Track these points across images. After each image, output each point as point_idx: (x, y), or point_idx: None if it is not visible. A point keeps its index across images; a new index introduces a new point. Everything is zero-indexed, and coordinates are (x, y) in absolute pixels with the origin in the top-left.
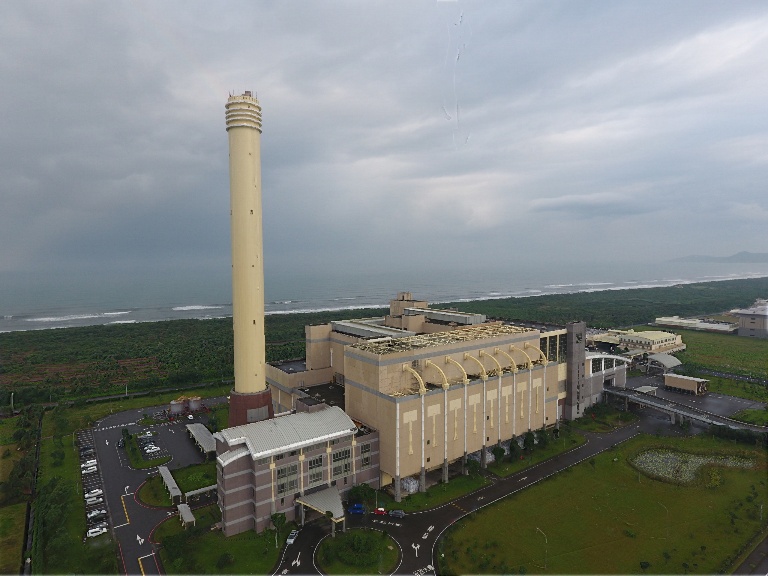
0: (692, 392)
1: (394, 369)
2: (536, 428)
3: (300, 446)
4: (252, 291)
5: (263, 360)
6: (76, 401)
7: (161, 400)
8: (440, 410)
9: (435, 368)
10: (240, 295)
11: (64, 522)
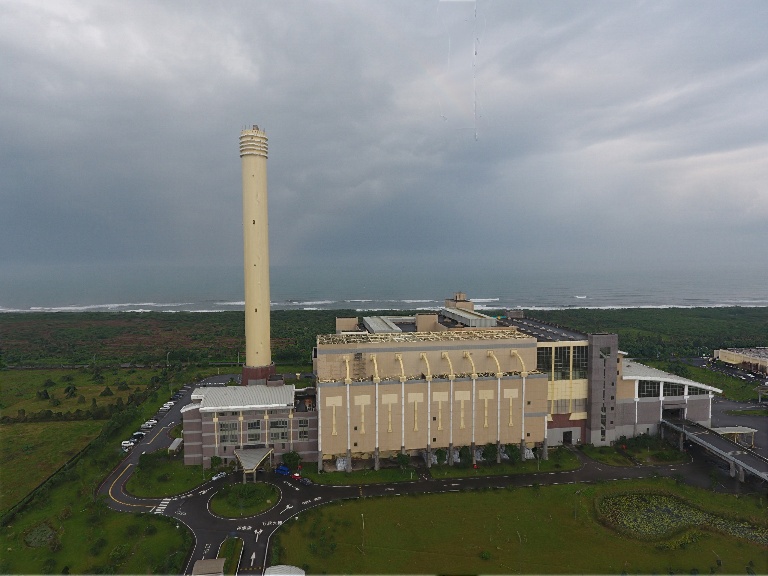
0: None
1: (334, 358)
2: (510, 442)
3: (238, 409)
4: (254, 285)
5: (265, 342)
6: (202, 363)
7: None
8: (370, 401)
9: None
10: (246, 288)
11: (119, 434)
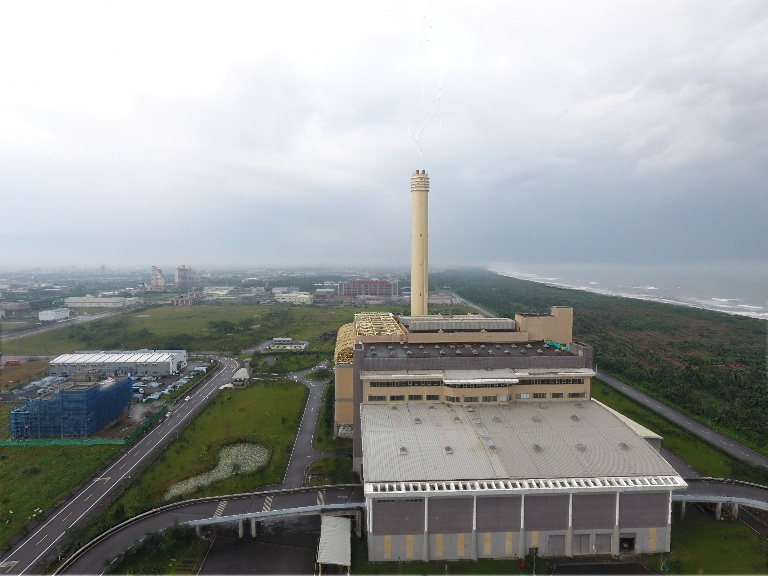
0: None
1: None
2: None
3: None
4: None
5: None
6: None
7: None
8: None
9: None
10: None
11: None
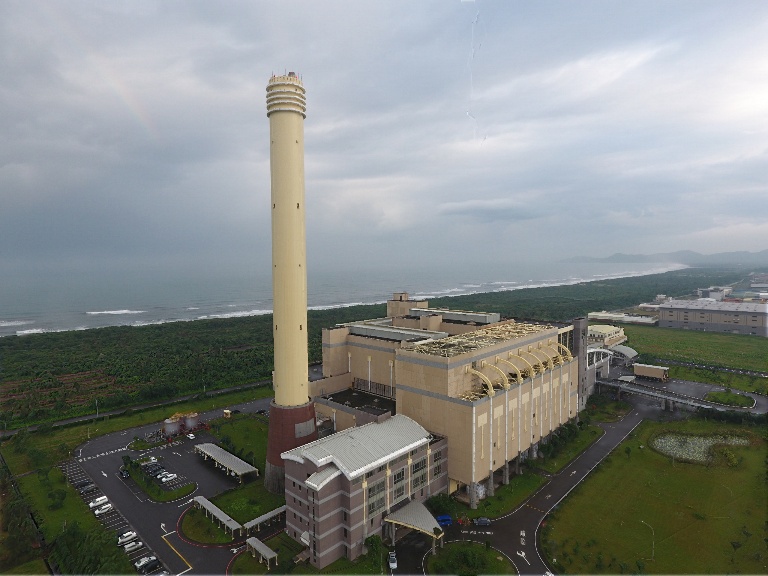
0: (660, 379)
1: (459, 372)
2: (564, 422)
3: (388, 460)
4: (298, 293)
5: None
6: (40, 427)
7: (143, 419)
8: (503, 411)
9: (494, 369)
10: (286, 298)
11: None
